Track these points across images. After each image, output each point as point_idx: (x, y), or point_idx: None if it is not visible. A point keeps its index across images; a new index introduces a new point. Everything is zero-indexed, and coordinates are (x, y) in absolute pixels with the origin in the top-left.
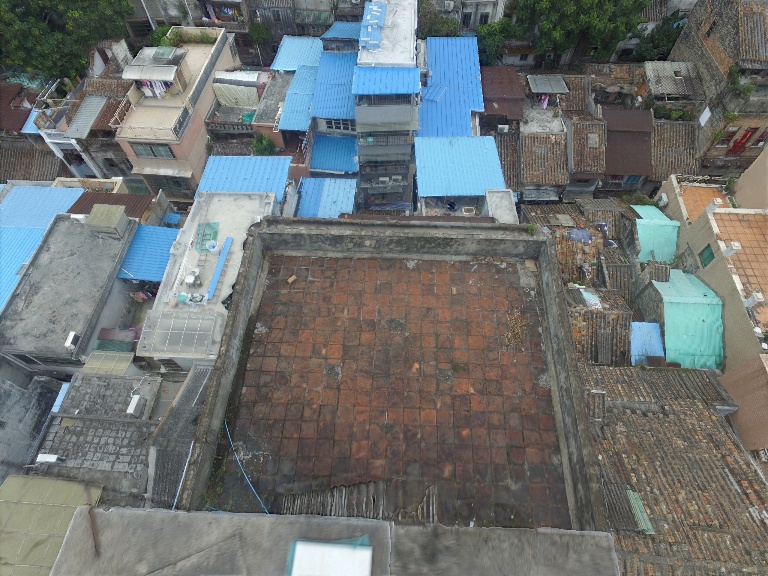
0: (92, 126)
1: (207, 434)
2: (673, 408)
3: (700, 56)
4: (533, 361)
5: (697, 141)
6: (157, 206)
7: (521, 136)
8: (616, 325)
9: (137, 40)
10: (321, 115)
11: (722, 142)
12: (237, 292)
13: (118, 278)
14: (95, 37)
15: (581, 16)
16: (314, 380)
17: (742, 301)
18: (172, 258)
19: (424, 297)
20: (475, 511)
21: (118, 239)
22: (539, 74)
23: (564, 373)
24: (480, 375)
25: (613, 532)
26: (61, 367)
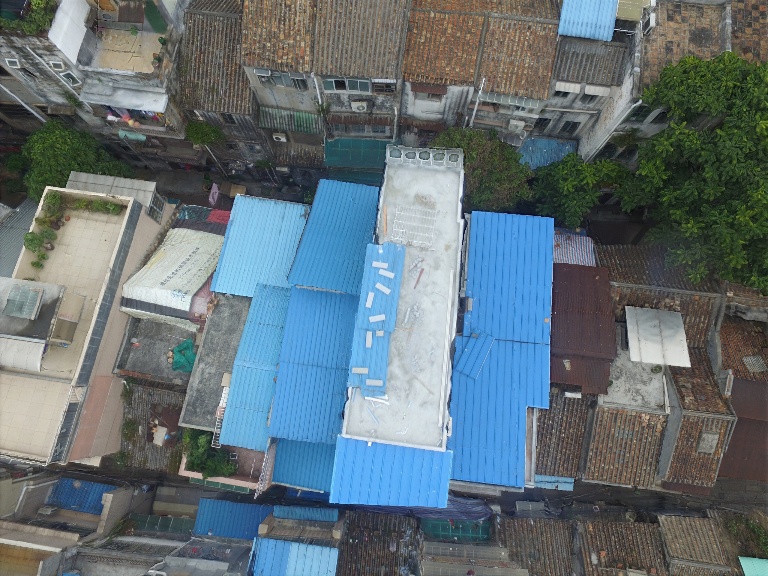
0: None
1: None
2: None
3: None
4: None
5: None
6: None
7: (597, 410)
8: None
9: (16, 121)
10: (286, 435)
11: None
12: None
13: None
14: None
15: (752, 278)
16: None
17: None
18: None
19: None
20: None
21: None
22: (644, 286)
23: None
24: None
25: None
26: None
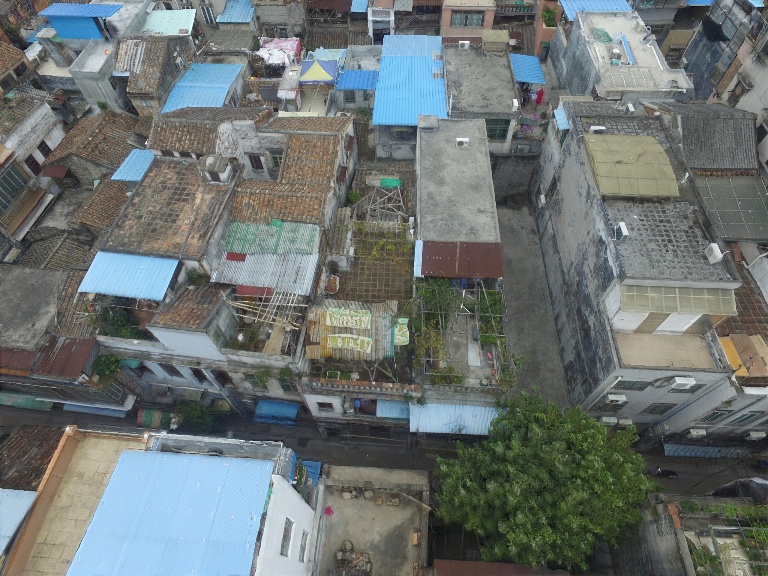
0: (414, 3)
1: None
2: None
3: None
4: None
5: None
6: None
7: None
8: None
9: None
10: None
11: None
12: None
13: None
14: None
15: None
16: None
17: None
18: None
19: None
20: None
21: (500, 57)
22: None
23: None
24: None
25: None
26: None
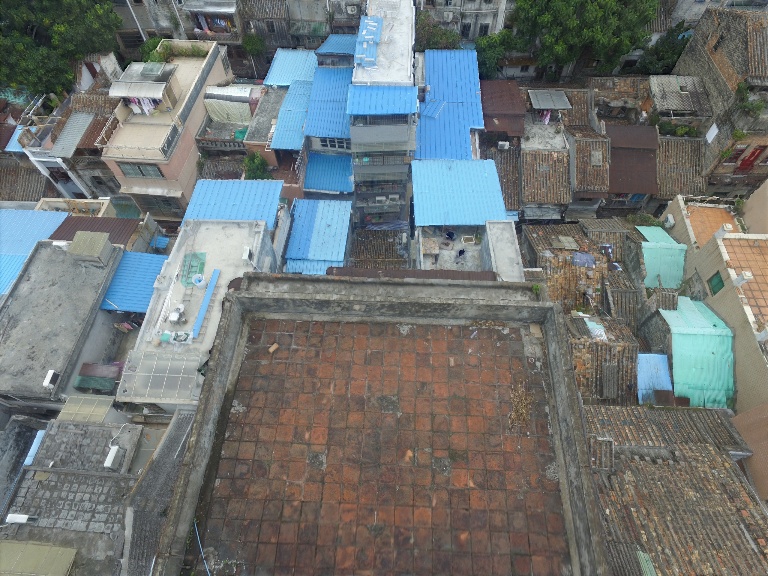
0: (78, 144)
1: (172, 546)
2: (684, 454)
3: (707, 70)
4: (539, 447)
5: (703, 158)
6: (144, 230)
7: (522, 153)
8: (622, 358)
9: (128, 51)
10: (315, 134)
11: (730, 160)
12: (211, 369)
13: (101, 309)
14: (82, 51)
15: (584, 30)
16: (295, 471)
17: (754, 334)
18: (156, 292)
19: (419, 369)
20: None
21: (102, 268)
22: (540, 88)
23: (574, 467)
24: (480, 465)
25: None
26: (41, 404)
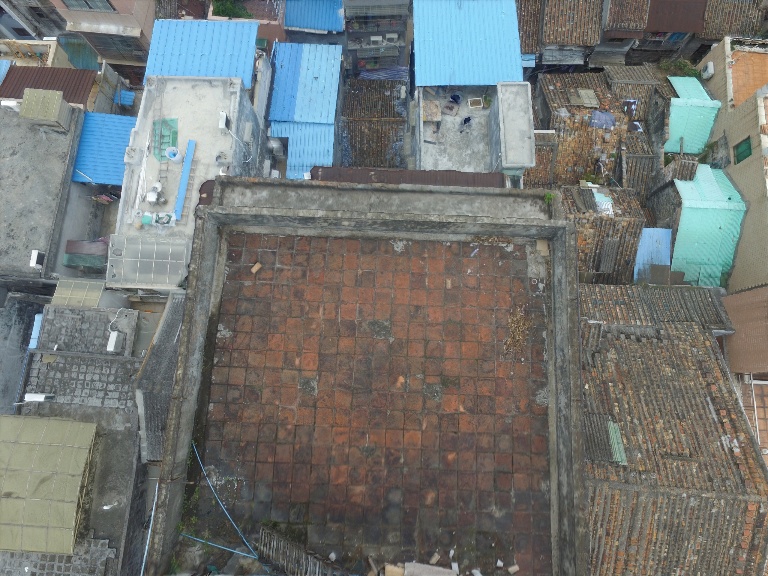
0: None
1: (172, 472)
2: (668, 332)
3: None
4: (532, 373)
5: None
6: (104, 83)
7: None
8: (625, 233)
9: None
10: None
11: None
12: (189, 299)
13: (74, 181)
14: None
15: None
16: (287, 396)
17: None
18: (128, 168)
19: (413, 292)
20: (456, 539)
21: (64, 133)
22: None
23: (565, 398)
24: (472, 390)
25: (588, 462)
26: (35, 279)
